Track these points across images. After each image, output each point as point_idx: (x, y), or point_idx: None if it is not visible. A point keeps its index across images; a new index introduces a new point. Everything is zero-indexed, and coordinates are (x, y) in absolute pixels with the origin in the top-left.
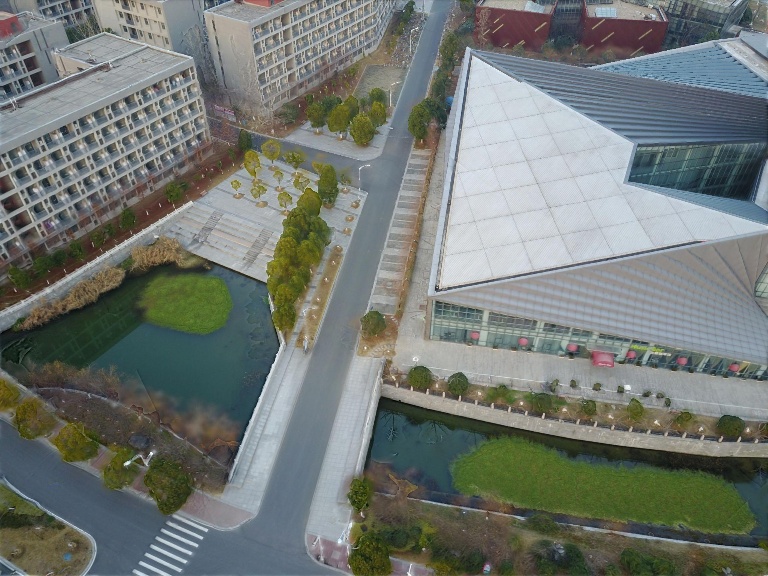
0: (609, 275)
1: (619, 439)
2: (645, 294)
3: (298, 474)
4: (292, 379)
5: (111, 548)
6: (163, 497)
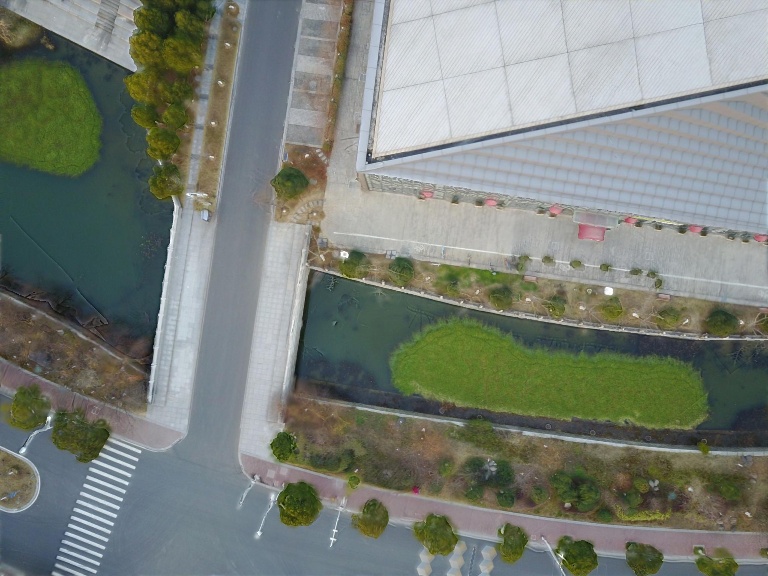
0: (627, 129)
1: (586, 327)
2: (674, 150)
3: (222, 389)
4: (197, 261)
5: (52, 472)
6: (79, 453)
